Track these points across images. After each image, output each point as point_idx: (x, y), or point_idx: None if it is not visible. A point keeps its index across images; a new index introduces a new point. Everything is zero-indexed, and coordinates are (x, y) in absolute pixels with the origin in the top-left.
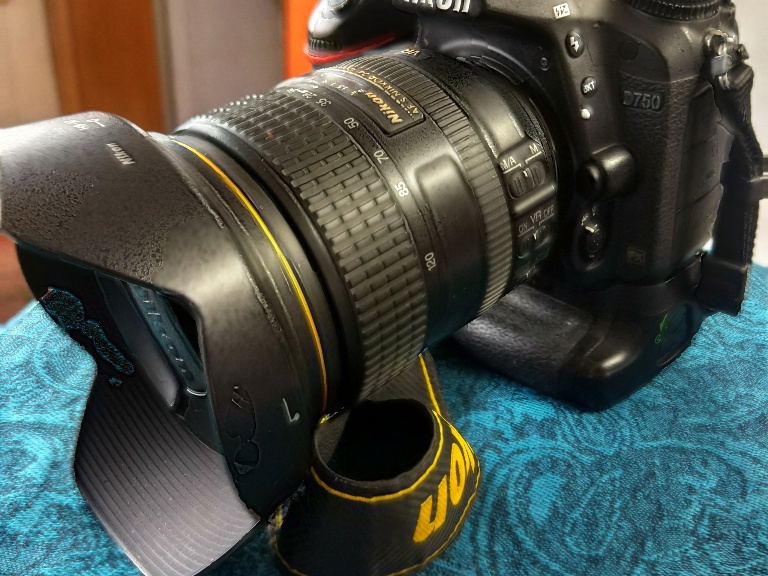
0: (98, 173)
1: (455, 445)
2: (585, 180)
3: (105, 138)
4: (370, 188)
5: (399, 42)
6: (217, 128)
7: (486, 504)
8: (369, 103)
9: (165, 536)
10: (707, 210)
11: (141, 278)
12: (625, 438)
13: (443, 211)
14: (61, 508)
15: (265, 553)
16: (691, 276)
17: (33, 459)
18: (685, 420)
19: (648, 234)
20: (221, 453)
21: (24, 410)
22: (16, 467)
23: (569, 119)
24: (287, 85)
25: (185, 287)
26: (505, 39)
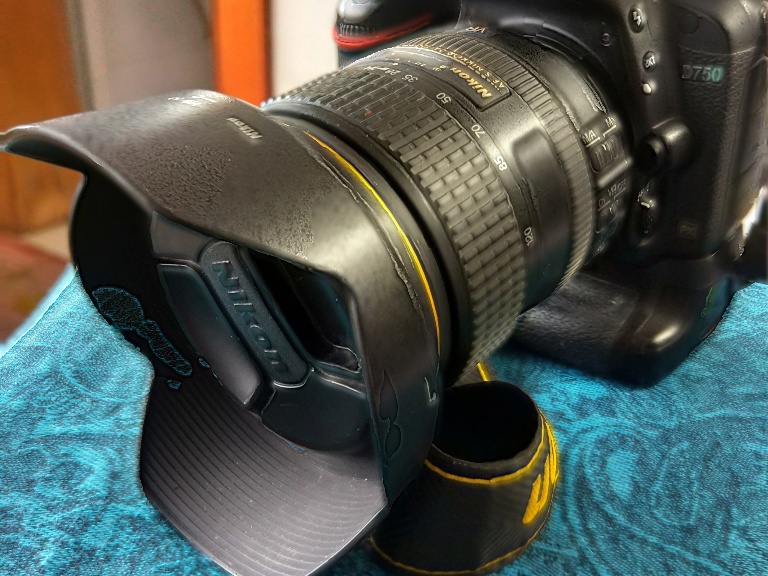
0: (230, 147)
1: (546, 424)
2: (645, 155)
3: (222, 113)
4: (473, 162)
5: (433, 26)
6: (309, 106)
7: (567, 484)
8: (456, 78)
9: (255, 539)
10: (749, 183)
11: (296, 254)
12: (681, 411)
13: (537, 185)
14: (133, 519)
15: (358, 549)
16: (730, 249)
17: (90, 471)
18: (731, 391)
19: (701, 207)
20: (311, 447)
21: (65, 422)
22: (73, 480)
23: (630, 94)
24: (357, 64)
25: (337, 262)
26: (564, 16)
